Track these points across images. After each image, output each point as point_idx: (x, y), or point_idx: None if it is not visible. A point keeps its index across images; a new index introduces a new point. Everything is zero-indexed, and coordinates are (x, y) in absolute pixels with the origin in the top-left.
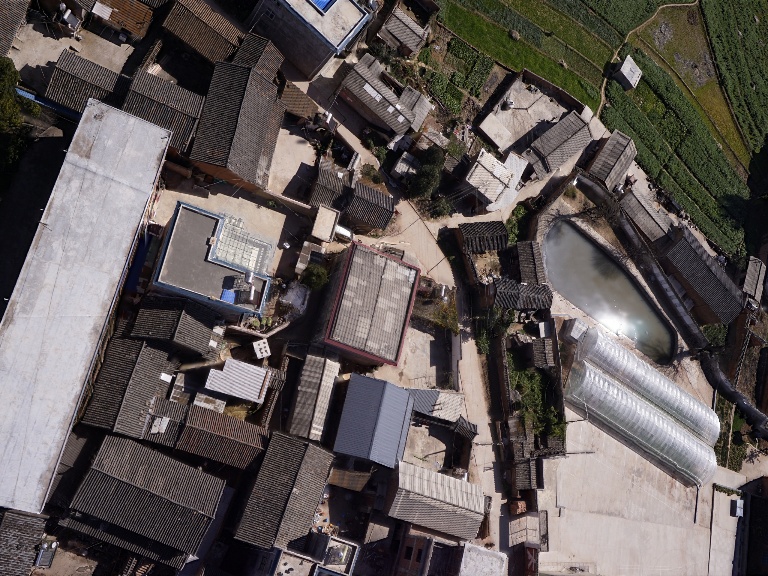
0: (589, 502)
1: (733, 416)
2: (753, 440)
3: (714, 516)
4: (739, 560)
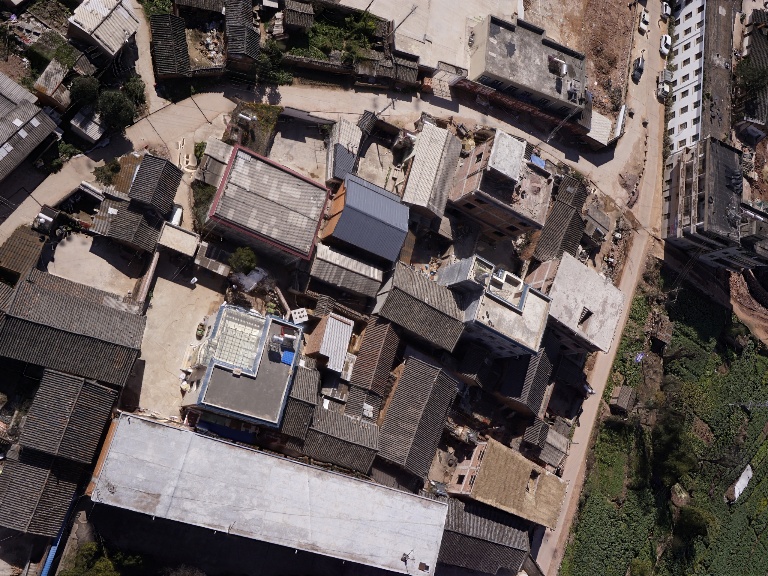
0: (421, 6)
1: None
2: None
3: None
4: None
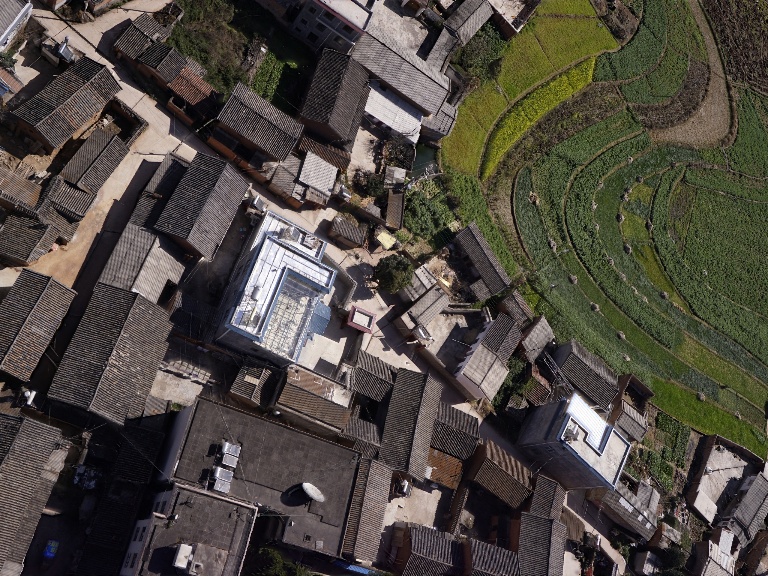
0: None
1: None
2: None
3: None
4: None
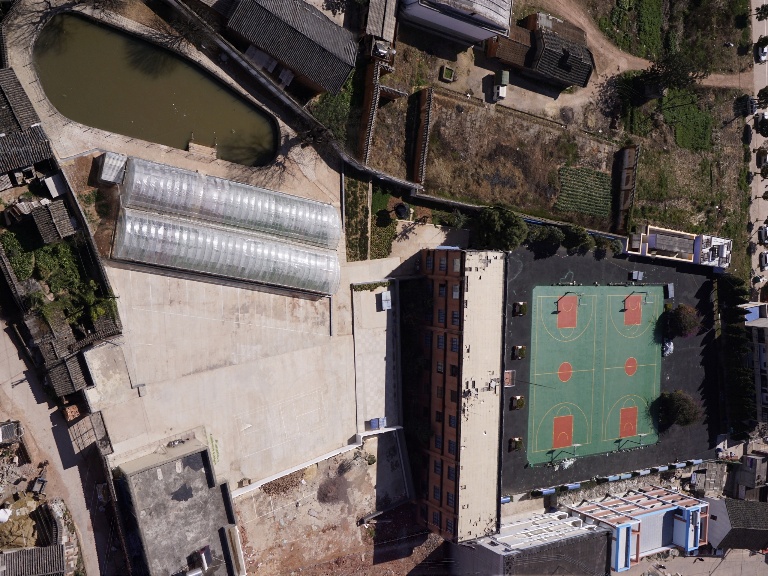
0: (180, 365)
1: (371, 197)
2: (405, 213)
3: (355, 319)
4: (393, 353)
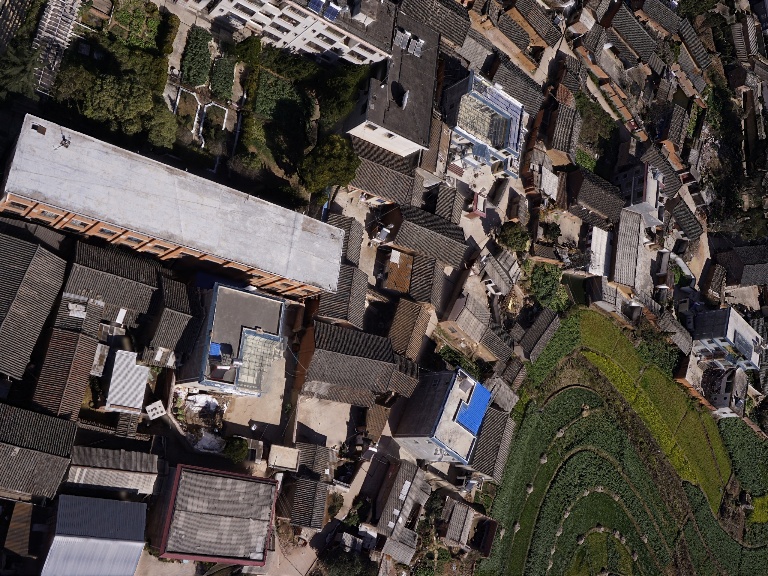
0: None
1: None
2: None
3: None
4: None
